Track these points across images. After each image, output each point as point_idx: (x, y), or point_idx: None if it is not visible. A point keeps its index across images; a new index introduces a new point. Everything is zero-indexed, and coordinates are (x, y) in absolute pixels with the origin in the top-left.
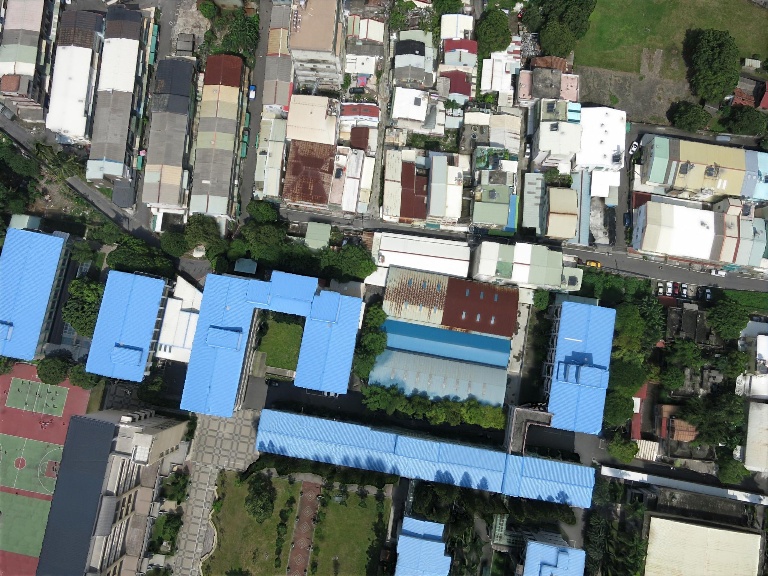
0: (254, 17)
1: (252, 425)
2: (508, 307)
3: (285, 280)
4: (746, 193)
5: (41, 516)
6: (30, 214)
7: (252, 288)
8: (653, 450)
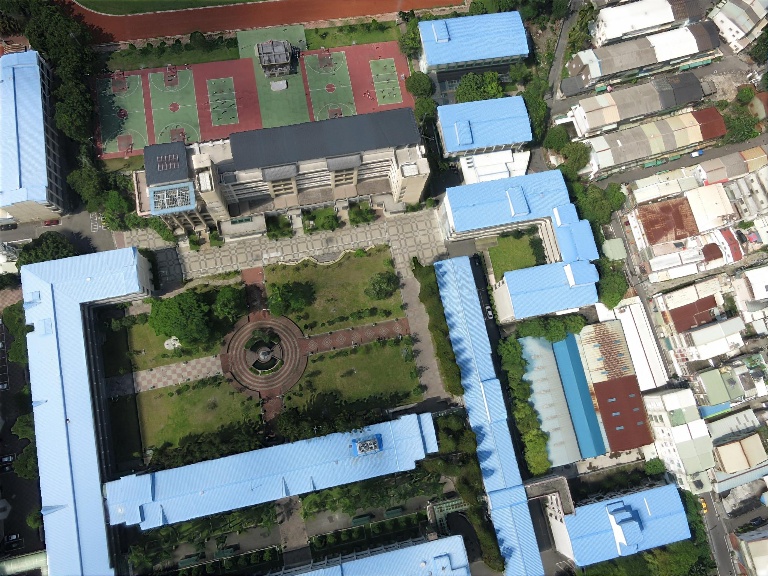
0: (756, 132)
1: (435, 256)
2: (638, 437)
3: (585, 232)
4: None
5: (296, 119)
6: (523, 24)
7: (568, 208)
8: None
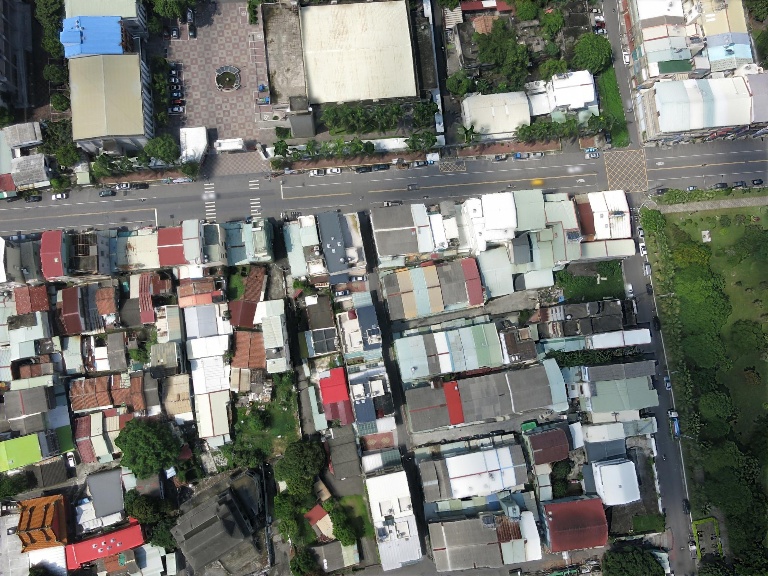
0: None
1: None
2: None
3: None
4: (710, 41)
5: None
6: None
7: None
8: (455, 23)
